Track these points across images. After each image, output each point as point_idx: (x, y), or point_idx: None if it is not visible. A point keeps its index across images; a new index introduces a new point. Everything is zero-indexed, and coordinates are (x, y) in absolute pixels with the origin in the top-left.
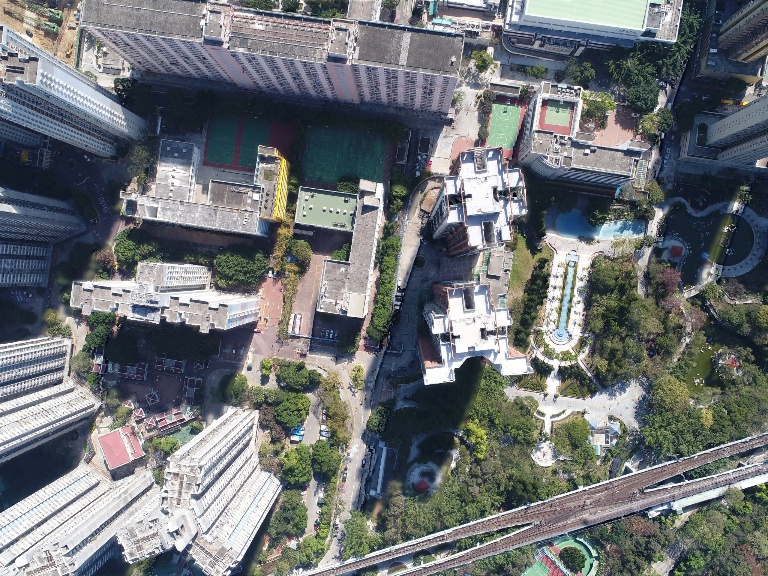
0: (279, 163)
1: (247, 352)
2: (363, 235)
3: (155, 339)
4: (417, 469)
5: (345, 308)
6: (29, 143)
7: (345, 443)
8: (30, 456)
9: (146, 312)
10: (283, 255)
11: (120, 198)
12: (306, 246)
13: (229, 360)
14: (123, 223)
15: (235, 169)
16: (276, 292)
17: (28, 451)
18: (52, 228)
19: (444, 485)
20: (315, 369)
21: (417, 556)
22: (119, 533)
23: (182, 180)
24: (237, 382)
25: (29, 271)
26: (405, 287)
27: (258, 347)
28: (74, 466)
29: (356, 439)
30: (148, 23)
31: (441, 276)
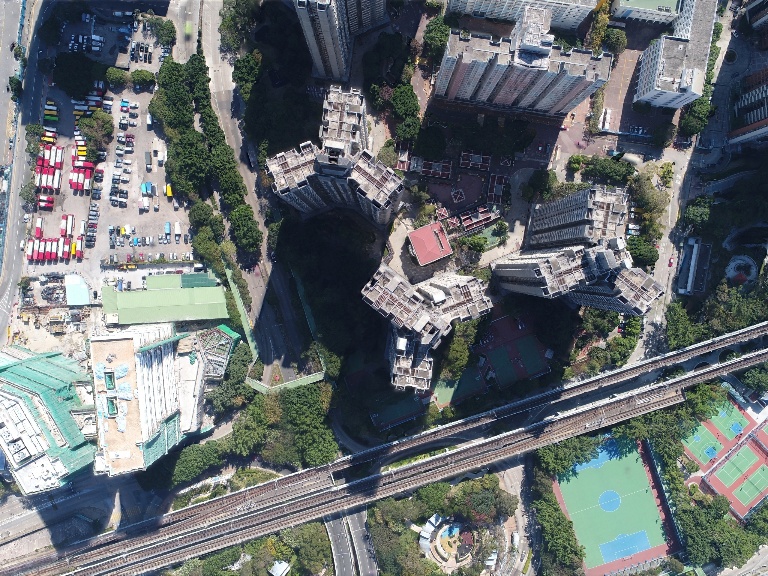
0: None
1: (552, 150)
2: (702, 11)
3: (465, 132)
4: (732, 263)
5: (687, 84)
6: None
7: (660, 237)
8: (336, 253)
9: (531, 59)
10: (599, 44)
11: None
12: (624, 34)
13: (534, 158)
14: (424, 16)
15: None
16: None
17: (334, 248)
18: (376, 5)
19: (766, 275)
20: (628, 163)
21: (724, 355)
22: (540, 266)
23: None
24: (551, 176)
25: (344, 55)
26: (715, 82)
27: (564, 145)
28: (375, 268)
29: (663, 238)
30: None
31: (752, 70)
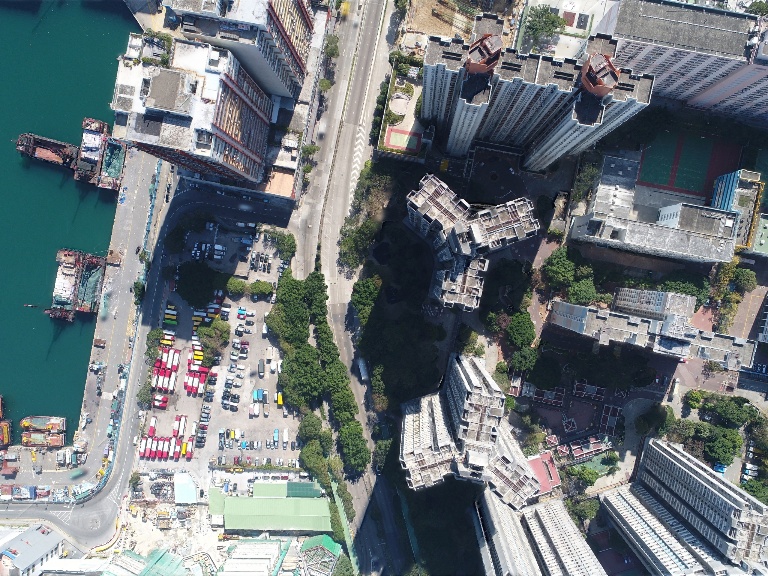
0: (758, 189)
1: (669, 382)
2: None
3: (581, 364)
4: None
5: None
6: (461, 153)
7: None
8: None
9: (671, 345)
10: (727, 284)
11: (549, 215)
12: (754, 276)
13: (649, 389)
14: (545, 240)
15: (670, 190)
16: (705, 321)
17: None
18: None
19: None
20: (750, 405)
21: None
22: None
23: (624, 200)
24: (668, 414)
25: None
26: None
27: (681, 378)
28: (481, 491)
29: None
30: (686, 38)
31: None
